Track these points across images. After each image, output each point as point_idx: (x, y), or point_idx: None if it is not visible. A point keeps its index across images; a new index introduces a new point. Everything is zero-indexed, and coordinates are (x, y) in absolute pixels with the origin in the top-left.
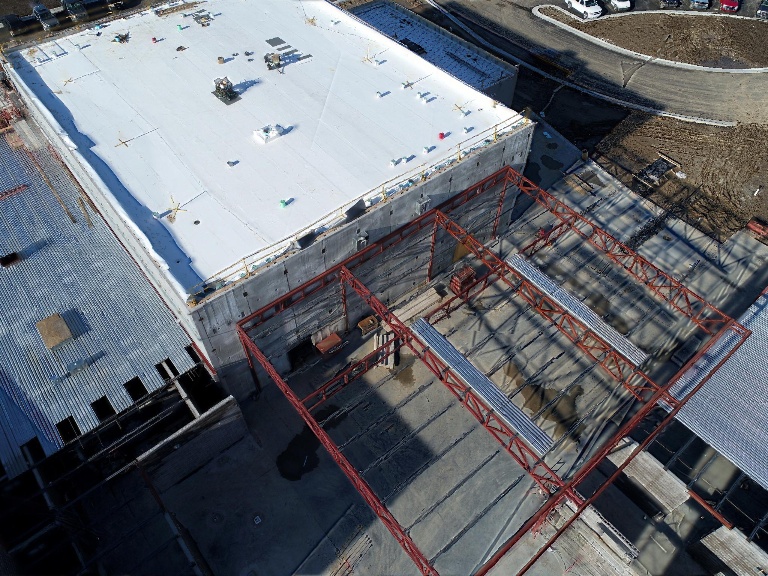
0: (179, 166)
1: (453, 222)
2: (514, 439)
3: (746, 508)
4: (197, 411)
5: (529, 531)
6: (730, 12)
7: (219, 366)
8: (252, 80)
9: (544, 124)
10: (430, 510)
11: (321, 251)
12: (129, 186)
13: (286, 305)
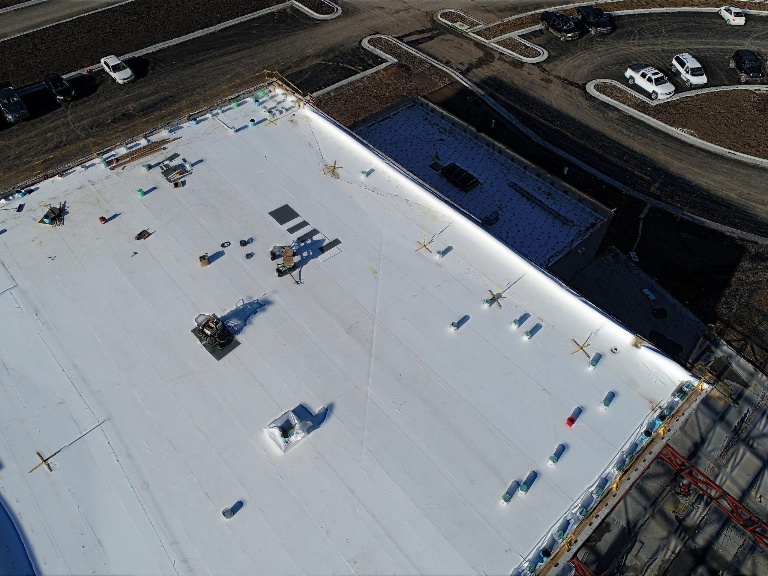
0: (139, 519)
1: None
2: None
3: None
4: None
5: None
6: None
7: None
8: (254, 300)
9: (641, 275)
10: None
11: None
12: None
13: None
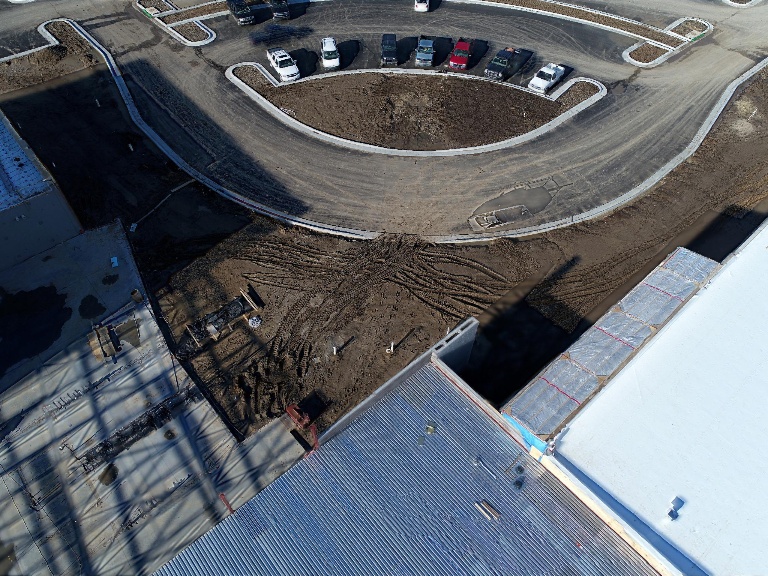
0: None
1: None
2: None
3: None
4: None
5: None
6: (459, 70)
7: None
8: None
9: (122, 244)
10: None
11: None
12: None
13: None
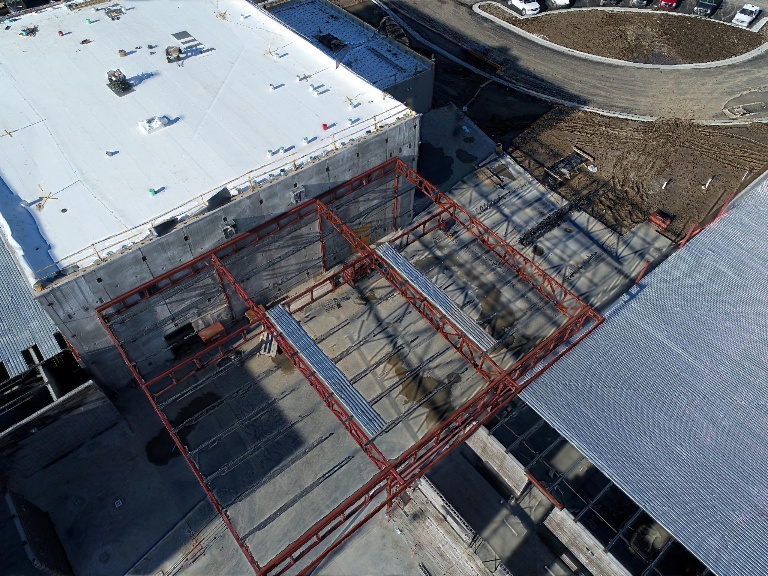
0: (59, 156)
1: (331, 212)
2: (349, 421)
3: (581, 490)
4: (55, 395)
5: (385, 514)
6: (668, 9)
7: (84, 352)
8: (149, 72)
9: (465, 118)
10: (251, 489)
11: (183, 239)
12: (5, 175)
13: (152, 292)
